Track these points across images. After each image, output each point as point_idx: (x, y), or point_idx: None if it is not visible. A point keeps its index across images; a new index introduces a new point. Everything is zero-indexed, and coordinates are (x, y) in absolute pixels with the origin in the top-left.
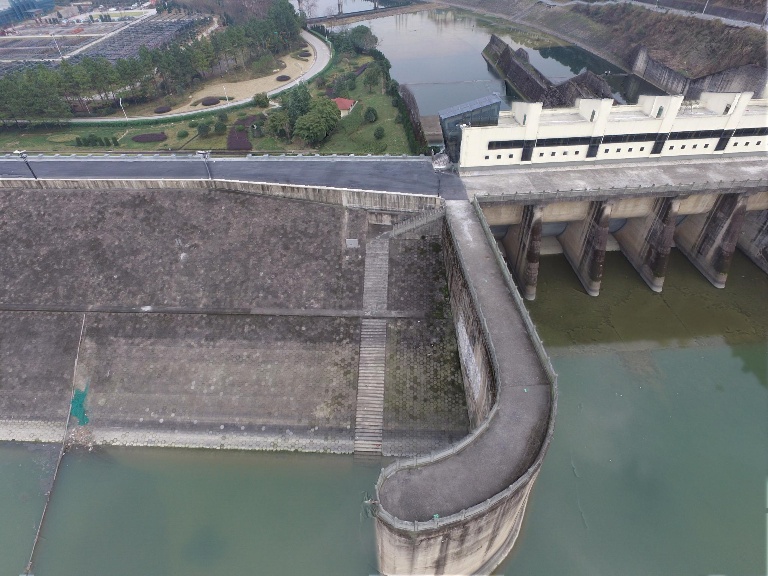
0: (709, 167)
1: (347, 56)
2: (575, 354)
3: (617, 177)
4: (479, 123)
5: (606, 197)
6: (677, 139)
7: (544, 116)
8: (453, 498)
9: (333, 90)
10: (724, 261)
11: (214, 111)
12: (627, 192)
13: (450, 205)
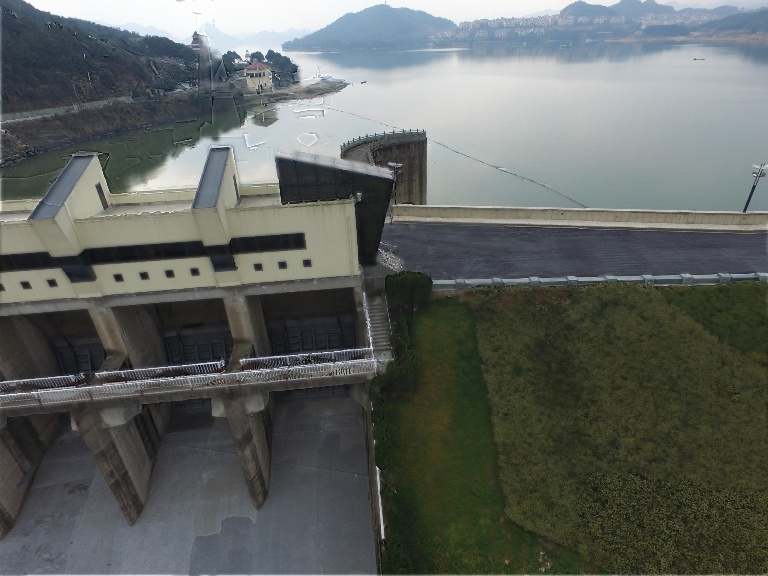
0: None
1: None
2: None
3: None
4: None
5: None
6: None
7: (162, 225)
8: None
9: None
10: None
11: None
12: None
13: None
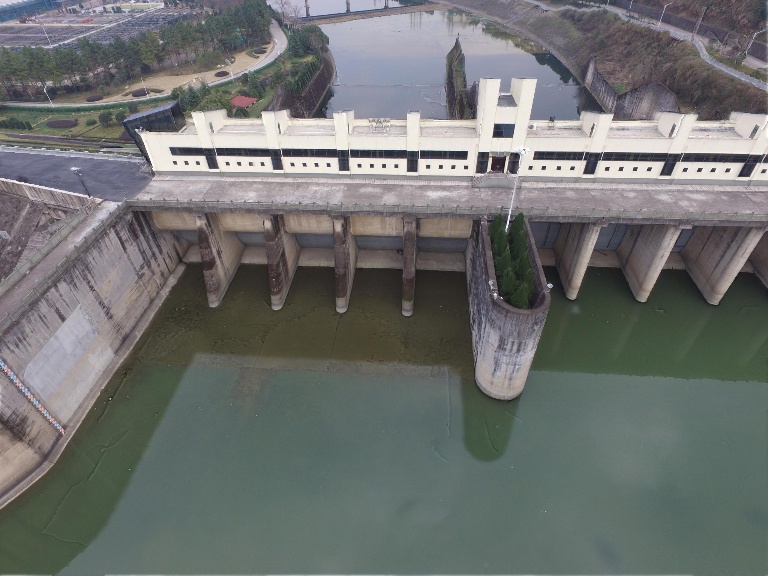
0: (396, 188)
1: (295, 55)
2: (201, 364)
3: (293, 192)
4: (159, 128)
5: (256, 211)
6: (362, 157)
7: (243, 125)
8: None
9: (247, 88)
10: (403, 288)
11: (133, 102)
12: (276, 207)
13: (106, 206)
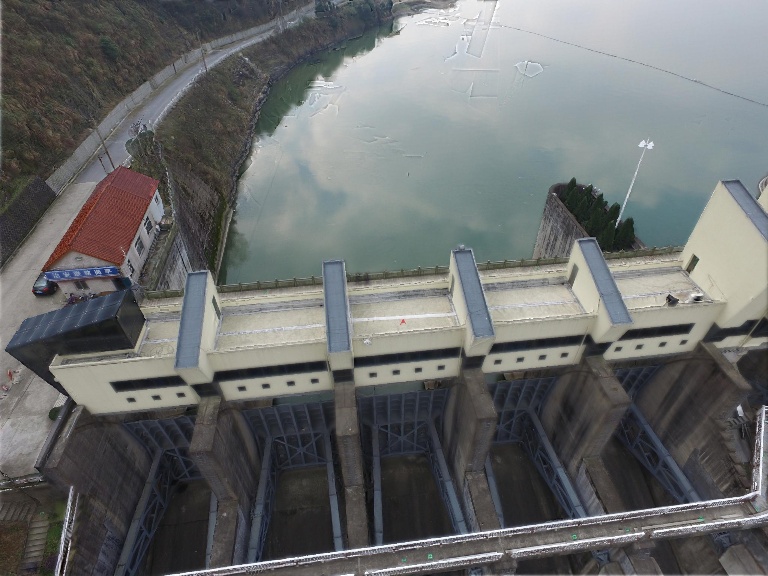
0: None
1: None
2: None
3: None
4: None
5: None
6: None
7: None
8: None
9: None
10: None
11: None
12: None
13: None
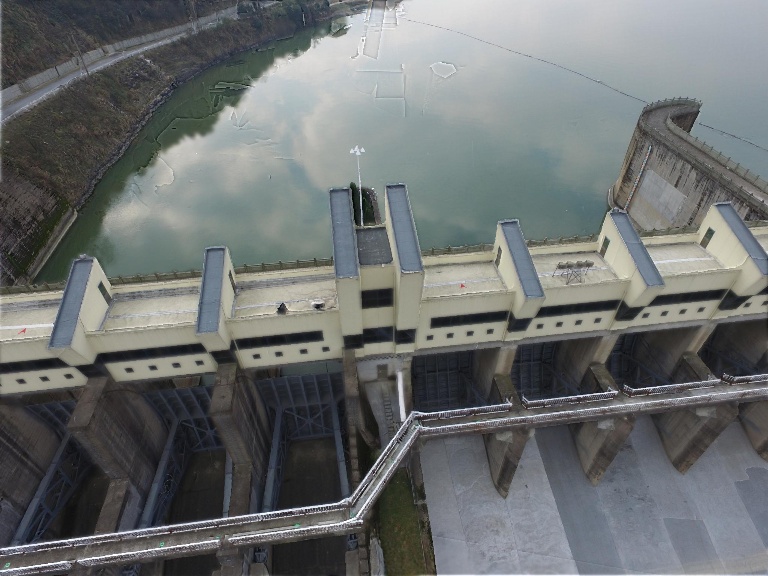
0: None
1: None
2: None
3: None
4: None
5: None
6: None
7: None
8: (668, 108)
9: None
10: None
11: None
12: None
13: None
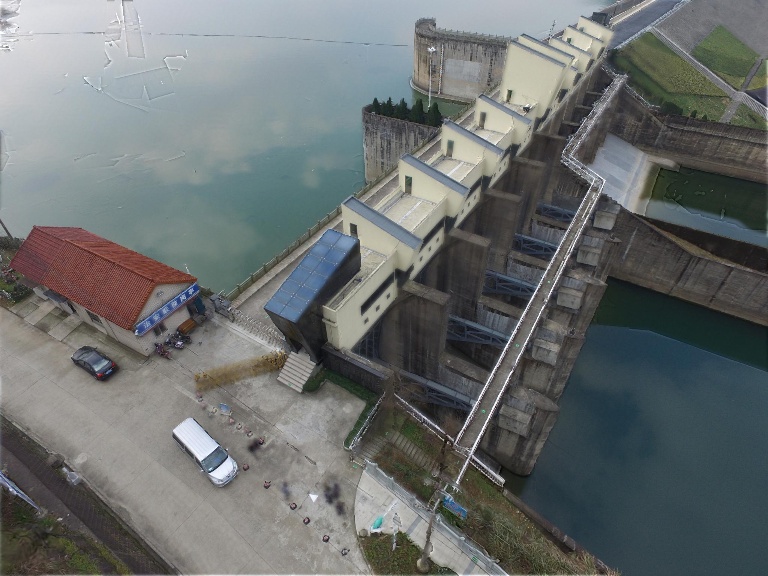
0: None
1: None
2: None
3: None
4: None
5: None
6: None
7: None
8: None
9: None
10: None
11: None
12: None
13: None
